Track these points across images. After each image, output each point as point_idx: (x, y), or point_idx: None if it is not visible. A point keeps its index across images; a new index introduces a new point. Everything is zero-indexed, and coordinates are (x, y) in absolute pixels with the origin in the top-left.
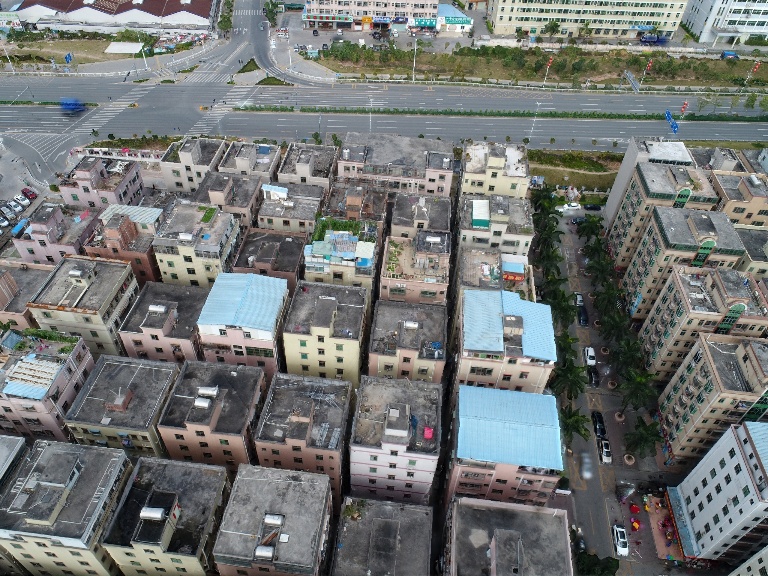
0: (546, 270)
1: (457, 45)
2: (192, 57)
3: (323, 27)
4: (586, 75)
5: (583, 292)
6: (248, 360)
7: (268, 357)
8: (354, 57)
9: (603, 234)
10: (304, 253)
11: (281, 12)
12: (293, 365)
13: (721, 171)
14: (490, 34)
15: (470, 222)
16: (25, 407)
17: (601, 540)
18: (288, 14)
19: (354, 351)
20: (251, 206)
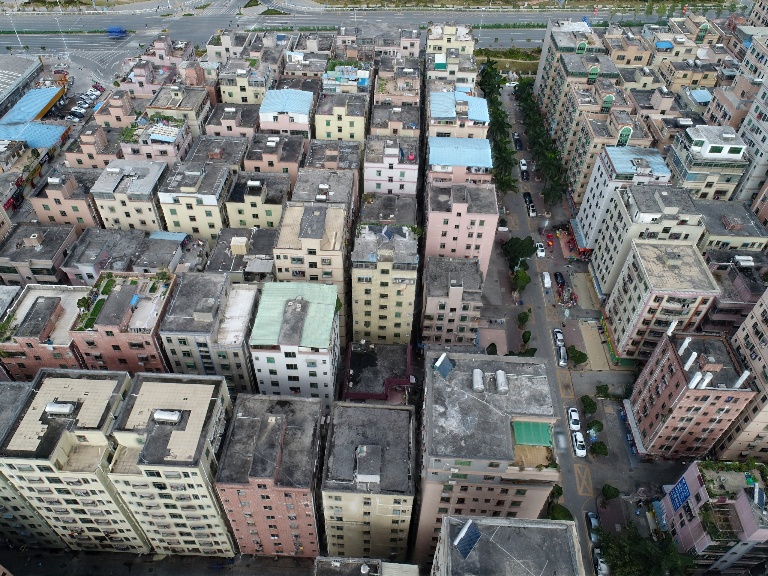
0: None
1: None
2: None
3: None
4: None
5: (519, 133)
6: None
7: None
8: None
9: (535, 99)
10: (322, 77)
11: None
12: None
13: (610, 35)
14: None
15: (433, 68)
16: (162, 151)
17: None
18: None
19: (361, 126)
20: (279, 66)
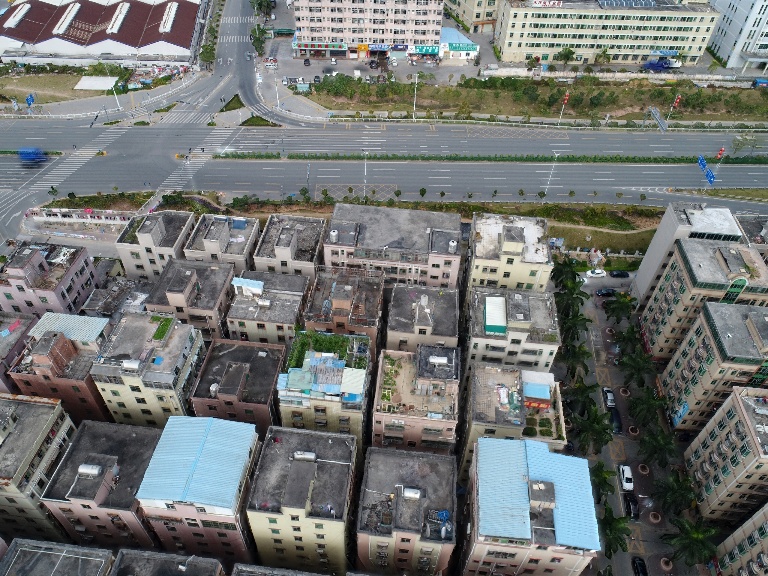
0: (572, 369)
1: (462, 77)
2: (170, 93)
3: (315, 55)
4: (605, 109)
5: (614, 387)
6: (205, 531)
7: (230, 530)
8: (348, 93)
9: None
10: (277, 386)
11: (270, 38)
12: (262, 538)
13: None
14: (498, 62)
15: (482, 325)
16: None
17: None
18: (277, 40)
19: (338, 530)
20: (219, 305)
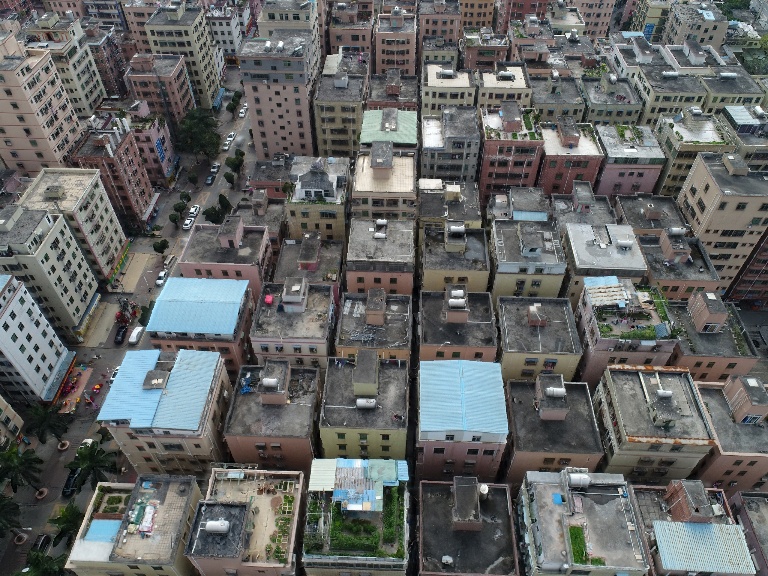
0: None
1: None
2: None
3: None
4: None
5: None
6: None
7: None
8: None
9: None
10: None
11: None
12: None
13: None
14: None
15: None
16: None
17: None
18: None
19: None
20: None
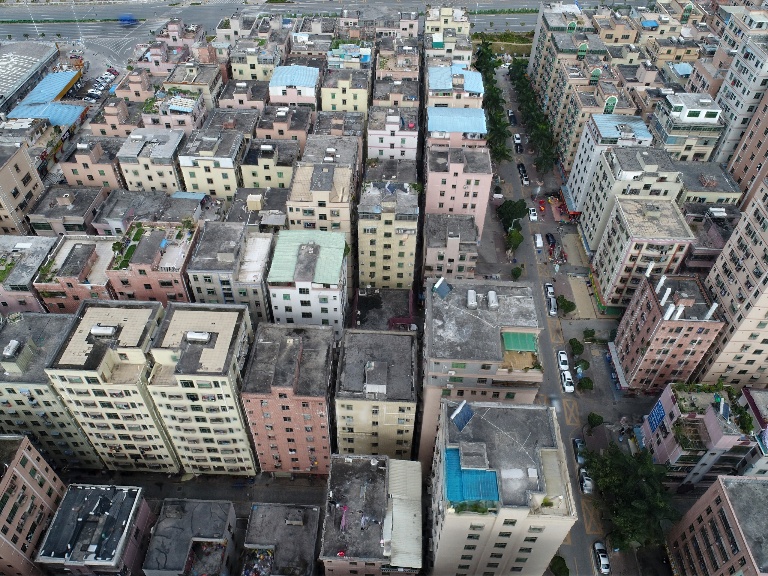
0: None
1: None
2: None
3: None
4: None
5: (514, 110)
6: None
7: None
8: None
9: (529, 79)
10: None
11: None
12: None
13: (599, 16)
14: None
15: (431, 47)
16: None
17: None
18: None
19: (364, 99)
20: (285, 46)
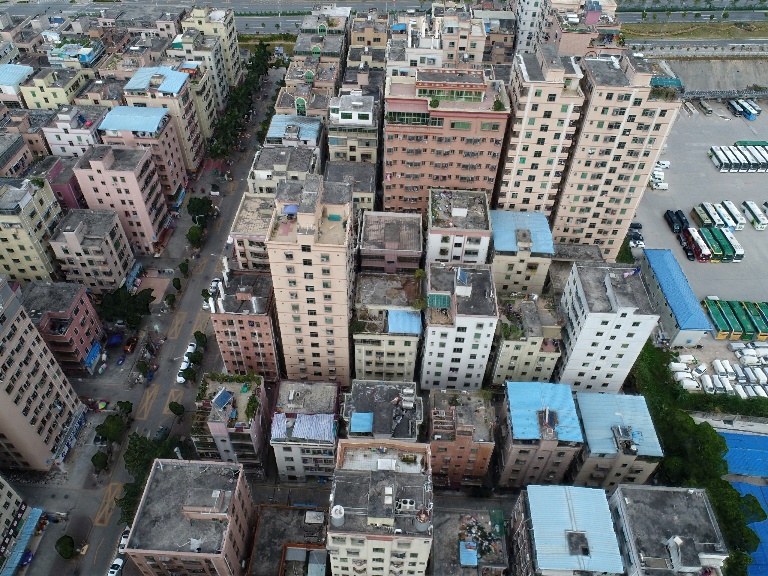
0: None
1: None
2: None
3: None
4: None
5: None
6: None
7: None
8: None
9: None
10: None
11: None
12: None
13: (359, 19)
14: None
15: None
16: None
17: (230, 213)
18: None
19: (64, 97)
20: (34, 45)
